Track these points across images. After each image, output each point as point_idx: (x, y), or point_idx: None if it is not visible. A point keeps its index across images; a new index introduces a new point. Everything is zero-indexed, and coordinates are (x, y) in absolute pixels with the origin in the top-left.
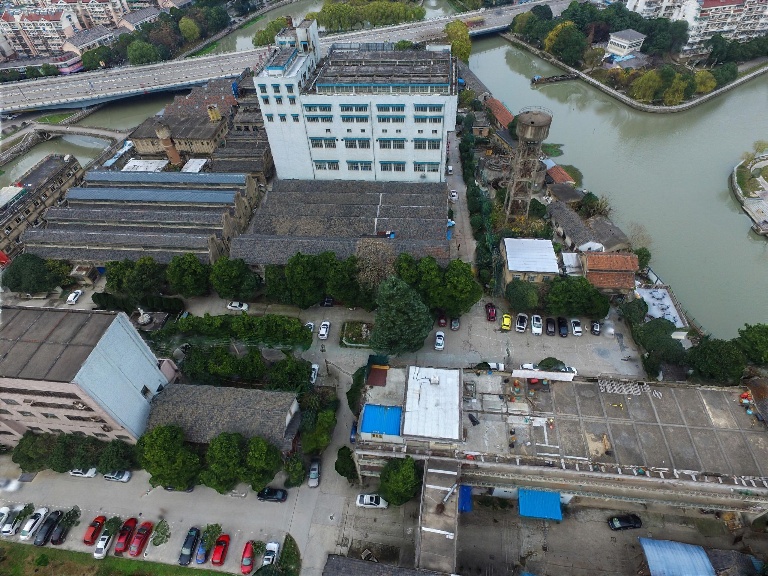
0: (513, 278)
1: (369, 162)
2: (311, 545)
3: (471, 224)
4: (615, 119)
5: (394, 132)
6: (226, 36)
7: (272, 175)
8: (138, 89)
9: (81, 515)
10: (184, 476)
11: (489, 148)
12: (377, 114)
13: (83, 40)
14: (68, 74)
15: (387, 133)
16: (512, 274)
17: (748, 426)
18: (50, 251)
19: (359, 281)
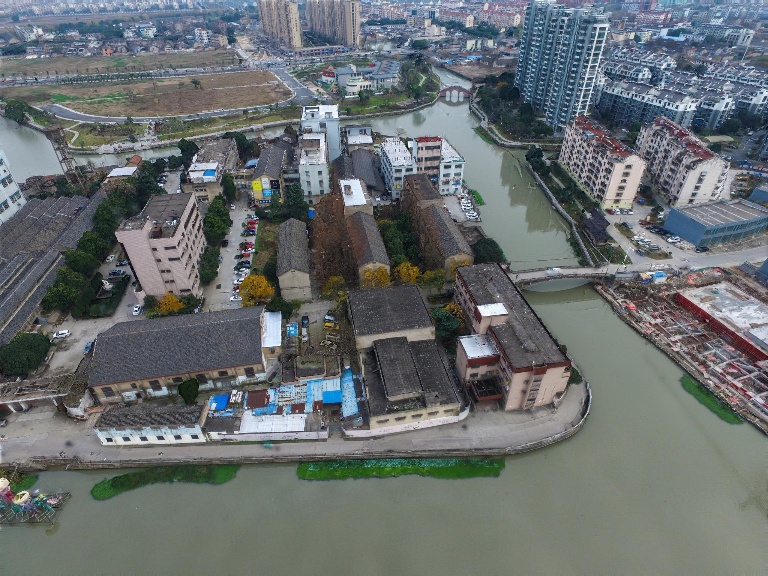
0: None
1: None
2: None
3: None
4: None
5: None
6: None
7: None
8: None
9: None
10: None
11: None
12: None
13: None
14: None
15: None
16: None
17: (217, 141)
18: None
19: (128, 194)
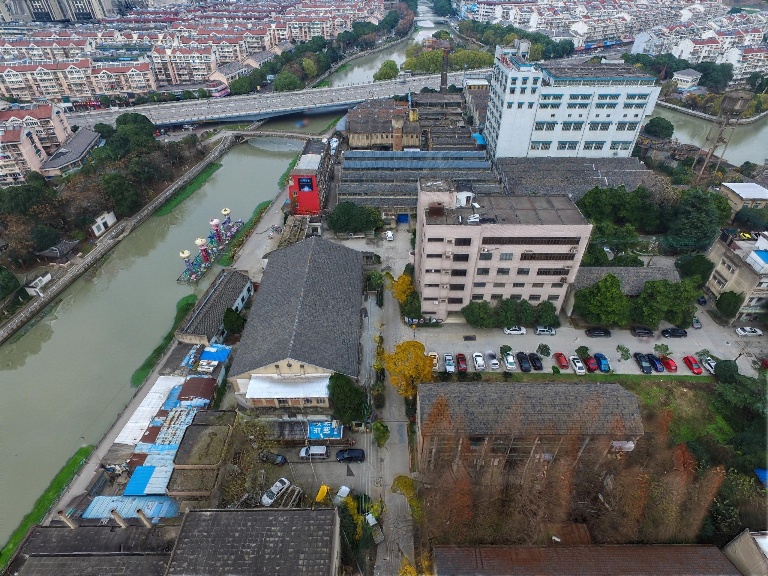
0: (742, 206)
1: (576, 142)
2: (728, 357)
3: (672, 182)
4: (693, 133)
5: (604, 116)
6: (329, 77)
7: None
8: (303, 106)
9: None
10: (626, 313)
11: None
12: (596, 102)
13: (228, 71)
14: None
15: (599, 117)
16: (744, 202)
17: None
18: (361, 201)
19: (656, 201)
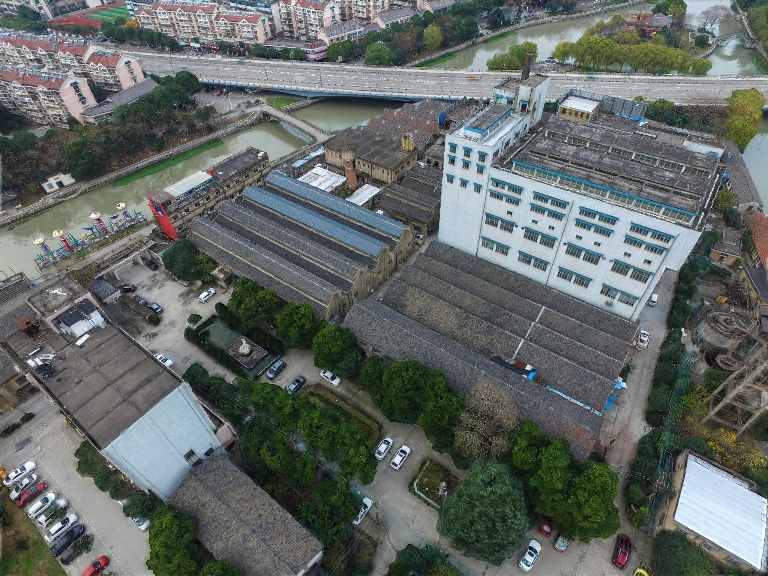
0: (677, 528)
1: (546, 262)
2: None
3: (649, 400)
4: None
5: (591, 243)
6: (467, 48)
7: (437, 228)
8: (358, 91)
9: (95, 543)
10: None
11: (725, 285)
12: (577, 216)
13: (336, 31)
14: (310, 61)
15: (581, 241)
16: (677, 524)
17: None
18: (206, 244)
19: (456, 436)
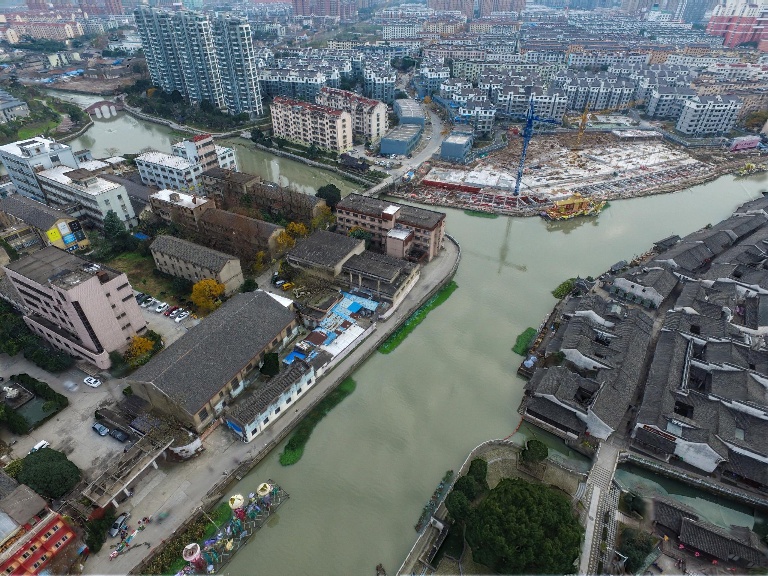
0: None
1: None
2: None
3: None
4: None
5: None
6: None
7: None
8: None
9: None
10: None
11: None
12: None
13: None
14: None
15: None
16: None
17: None
18: (0, 483)
19: None
